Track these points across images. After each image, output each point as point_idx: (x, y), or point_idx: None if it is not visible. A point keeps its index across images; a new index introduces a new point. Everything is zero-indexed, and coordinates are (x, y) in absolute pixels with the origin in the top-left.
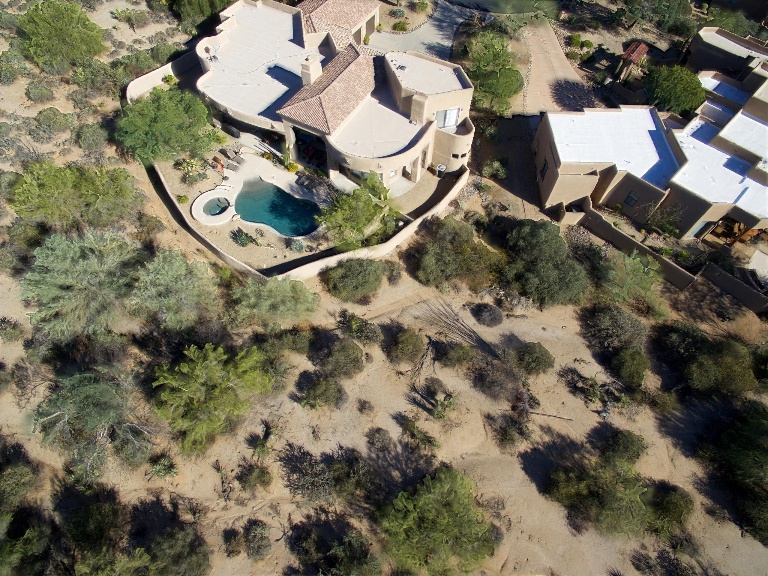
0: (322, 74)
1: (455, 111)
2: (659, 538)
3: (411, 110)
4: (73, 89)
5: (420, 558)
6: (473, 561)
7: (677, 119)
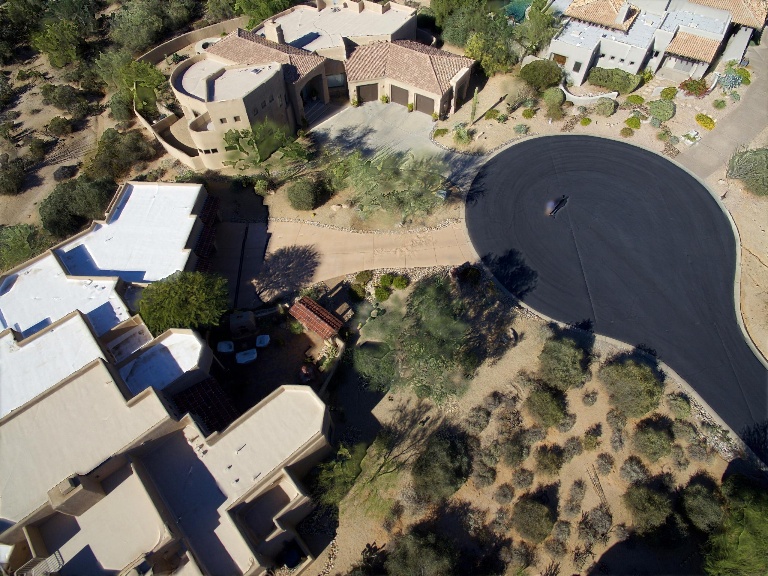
0: (278, 43)
1: None
2: None
3: None
4: None
5: None
6: None
7: None
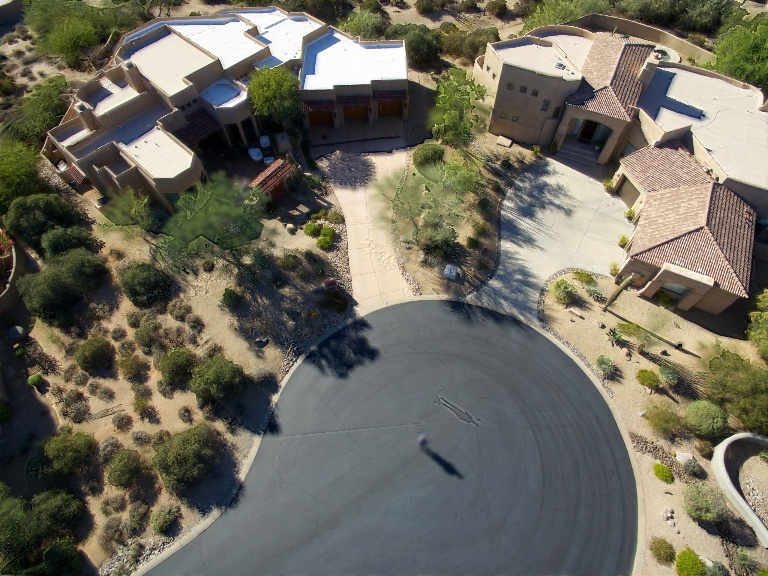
0: None
1: None
2: None
3: None
4: None
5: None
6: None
7: None
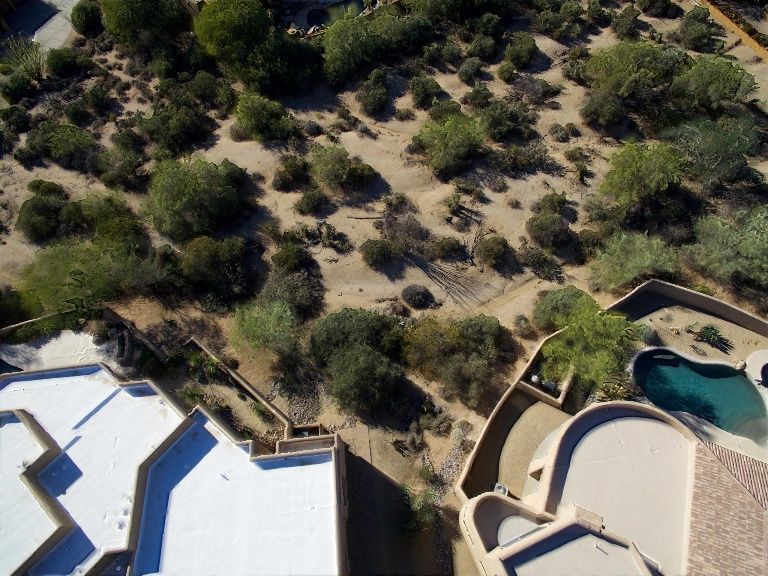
0: None
1: None
2: None
3: None
4: None
5: None
6: None
7: None
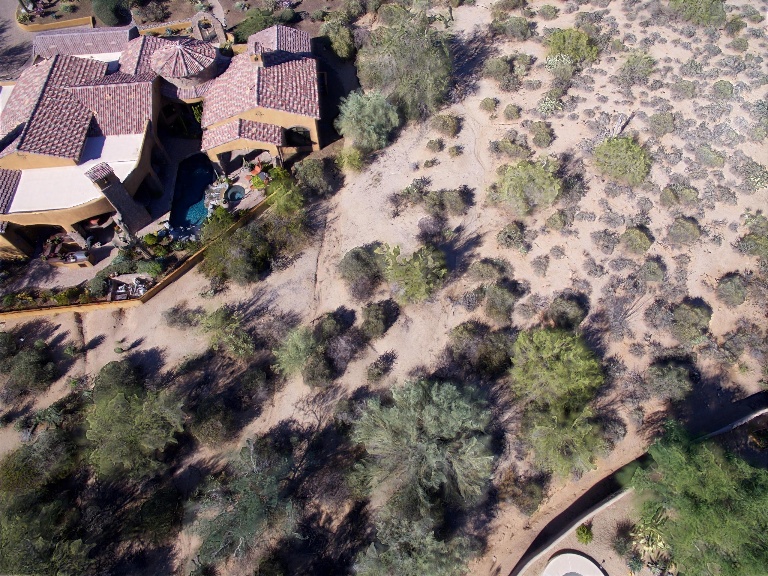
0: None
1: None
2: None
3: None
4: (761, 323)
5: None
6: None
7: None
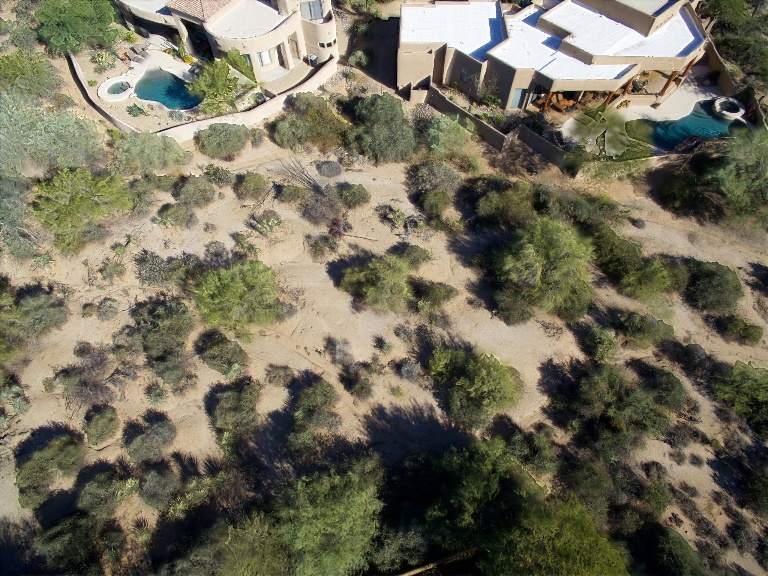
0: None
1: (318, 3)
2: (422, 317)
3: (277, 1)
4: None
5: (231, 326)
6: (272, 329)
7: (517, 9)
